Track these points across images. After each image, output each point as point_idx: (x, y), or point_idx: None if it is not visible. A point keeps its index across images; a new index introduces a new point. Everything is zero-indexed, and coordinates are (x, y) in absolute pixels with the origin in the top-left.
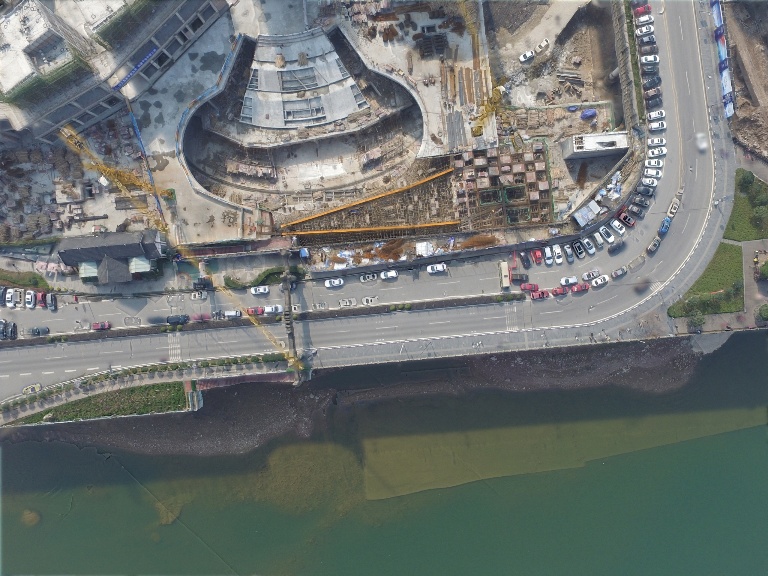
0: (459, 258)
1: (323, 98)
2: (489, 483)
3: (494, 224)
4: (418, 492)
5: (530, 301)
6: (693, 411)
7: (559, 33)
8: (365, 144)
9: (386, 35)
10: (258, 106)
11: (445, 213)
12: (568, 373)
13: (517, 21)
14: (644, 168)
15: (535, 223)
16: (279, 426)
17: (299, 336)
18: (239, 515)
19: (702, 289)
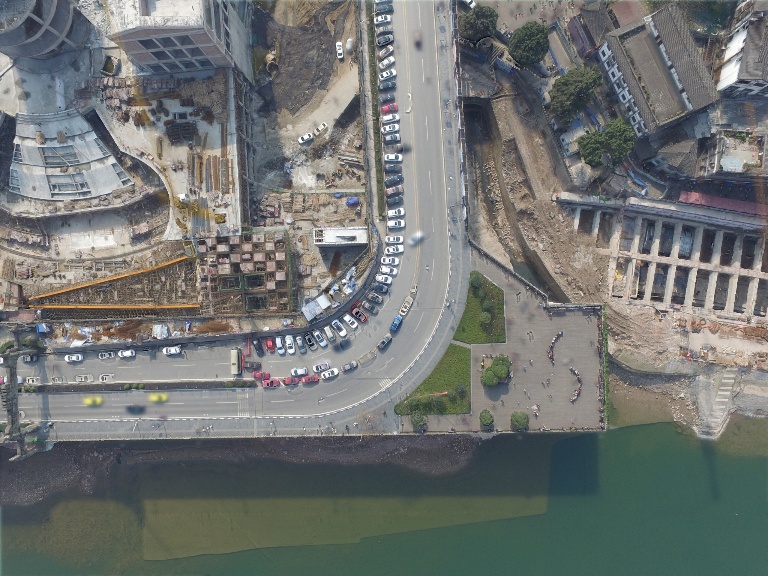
0: (195, 342)
1: (85, 174)
2: (265, 552)
3: (233, 310)
4: (195, 556)
5: (262, 389)
6: (470, 495)
7: (337, 118)
8: (133, 218)
9: (137, 120)
10: (24, 178)
11: (188, 296)
12: (343, 450)
13: (299, 103)
14: (381, 264)
15: (273, 312)
16: (62, 481)
17: (38, 407)
18: (21, 565)
19: (429, 389)
